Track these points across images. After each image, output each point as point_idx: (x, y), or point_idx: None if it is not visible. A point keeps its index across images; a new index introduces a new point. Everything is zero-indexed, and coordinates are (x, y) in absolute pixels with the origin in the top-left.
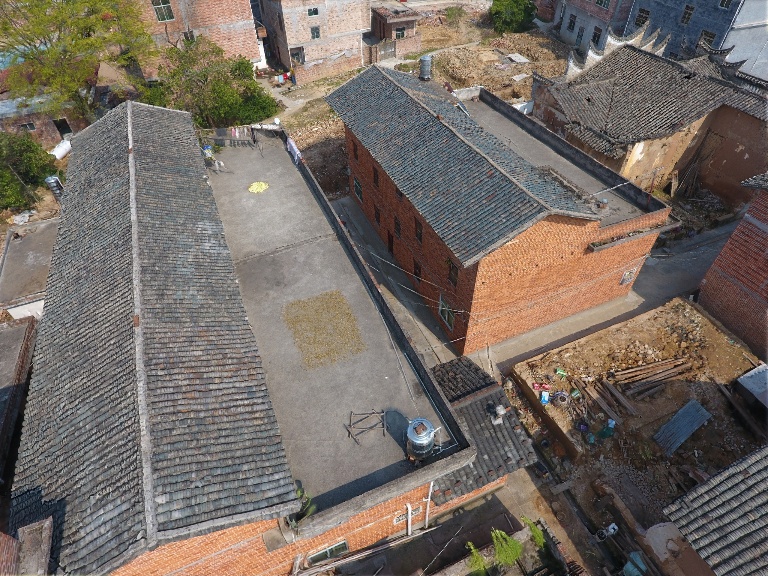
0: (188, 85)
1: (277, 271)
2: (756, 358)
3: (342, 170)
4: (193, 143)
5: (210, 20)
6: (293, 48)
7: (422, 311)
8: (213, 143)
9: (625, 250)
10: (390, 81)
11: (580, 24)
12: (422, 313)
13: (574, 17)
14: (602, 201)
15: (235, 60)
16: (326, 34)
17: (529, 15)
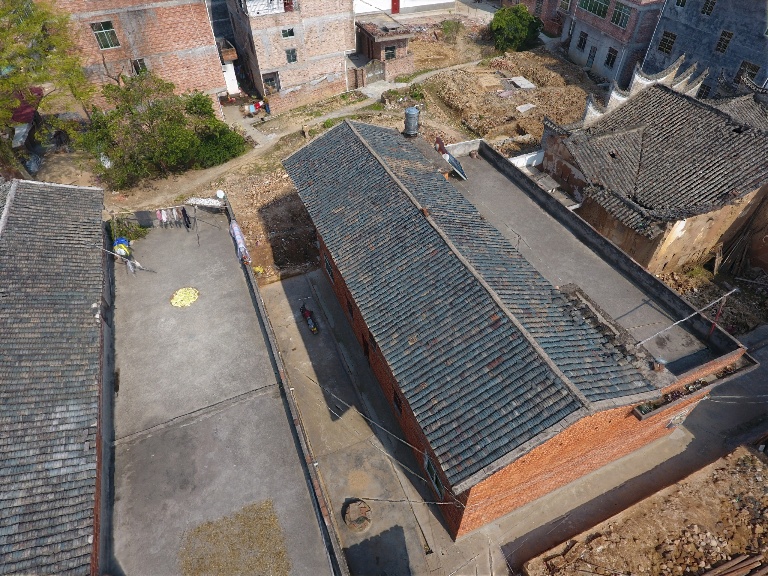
0: (128, 130)
1: (186, 458)
2: None
3: (313, 234)
4: (94, 242)
5: (164, 46)
6: (266, 73)
7: (404, 452)
8: (137, 224)
9: None
10: (364, 146)
11: (592, 43)
12: (404, 456)
13: (585, 35)
14: (657, 361)
15: (190, 95)
16: (304, 57)
17: (534, 31)
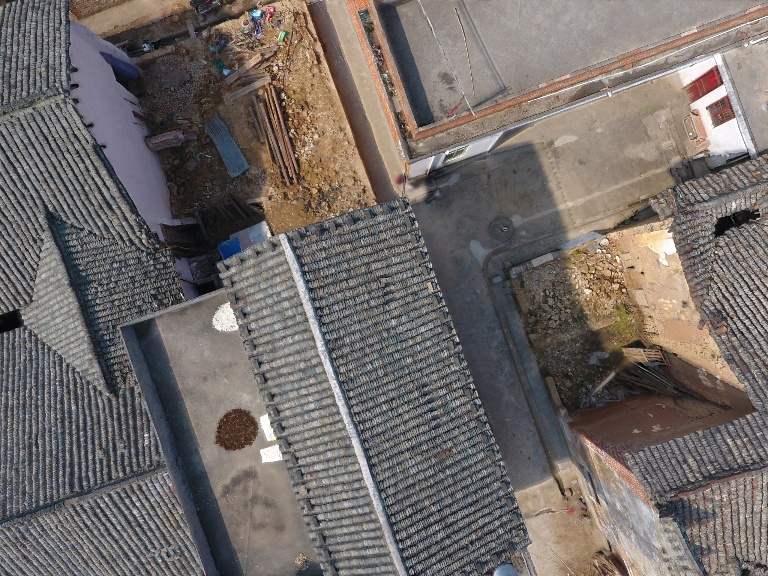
0: None
1: None
2: None
3: None
4: None
5: None
6: None
7: None
8: None
9: None
10: None
11: None
12: None
13: None
14: None
15: None
16: None
17: None
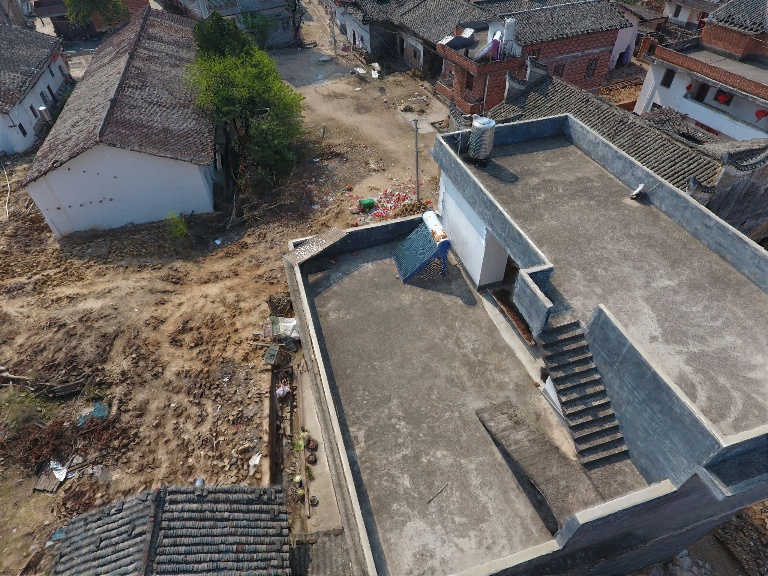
0: None
1: None
2: None
3: None
4: None
5: None
6: None
7: None
8: None
9: None
10: None
11: None
12: None
13: None
14: None
15: None
16: None
17: None
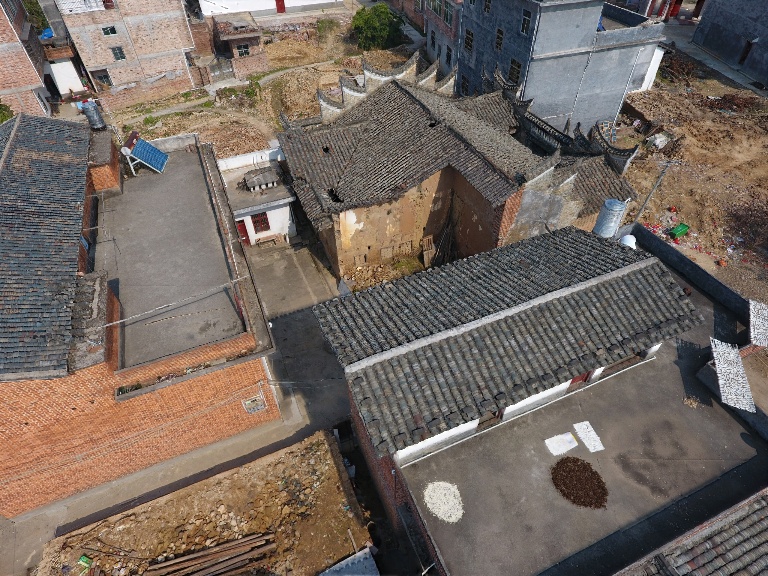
0: None
1: None
2: (365, 536)
3: None
4: None
5: None
6: (95, 71)
7: None
8: None
9: (210, 383)
10: None
11: None
12: None
13: (434, 34)
14: None
15: None
16: (133, 55)
17: (396, 30)
